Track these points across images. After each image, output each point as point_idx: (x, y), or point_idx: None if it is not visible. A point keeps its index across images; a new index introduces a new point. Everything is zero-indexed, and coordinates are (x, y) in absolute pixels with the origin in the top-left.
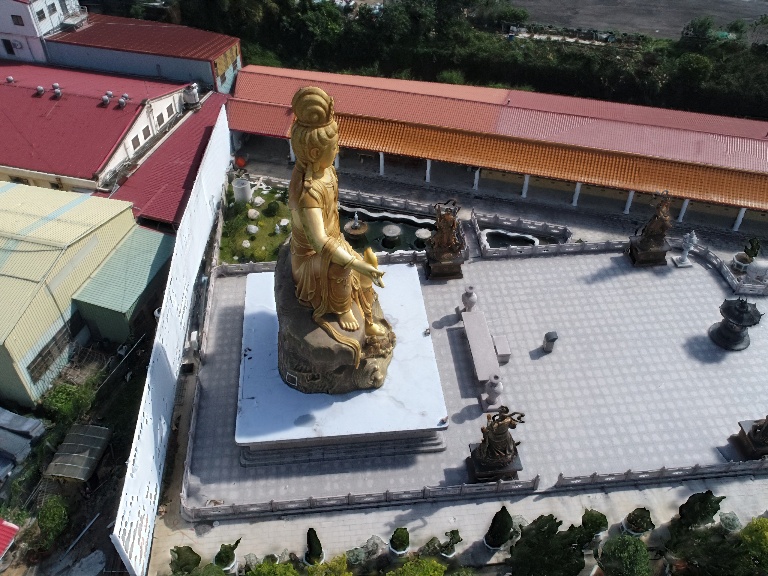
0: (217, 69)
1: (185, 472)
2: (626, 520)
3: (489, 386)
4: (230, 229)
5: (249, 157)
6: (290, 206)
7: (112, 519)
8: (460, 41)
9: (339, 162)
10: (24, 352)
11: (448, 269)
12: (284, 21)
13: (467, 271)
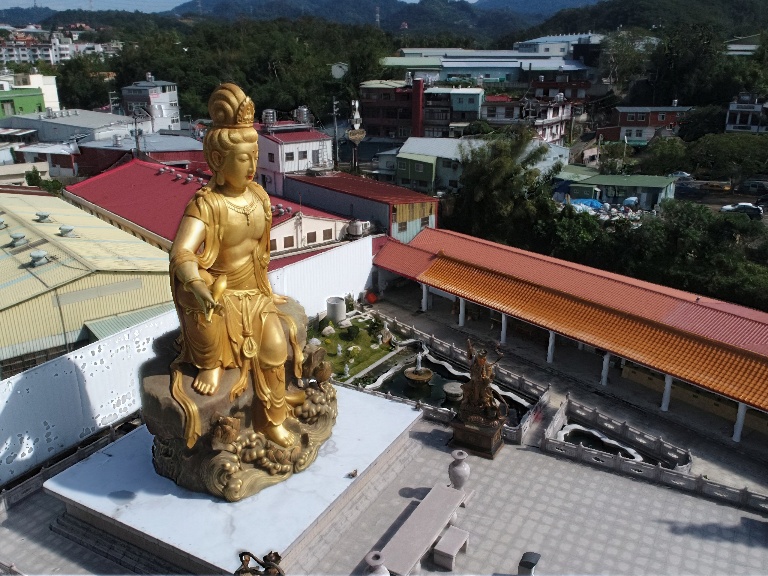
0: (396, 215)
1: None
2: None
3: (366, 568)
4: None
5: (386, 298)
6: None
7: None
8: (724, 269)
9: (467, 322)
10: (2, 344)
11: (475, 439)
12: (538, 224)
13: (506, 455)
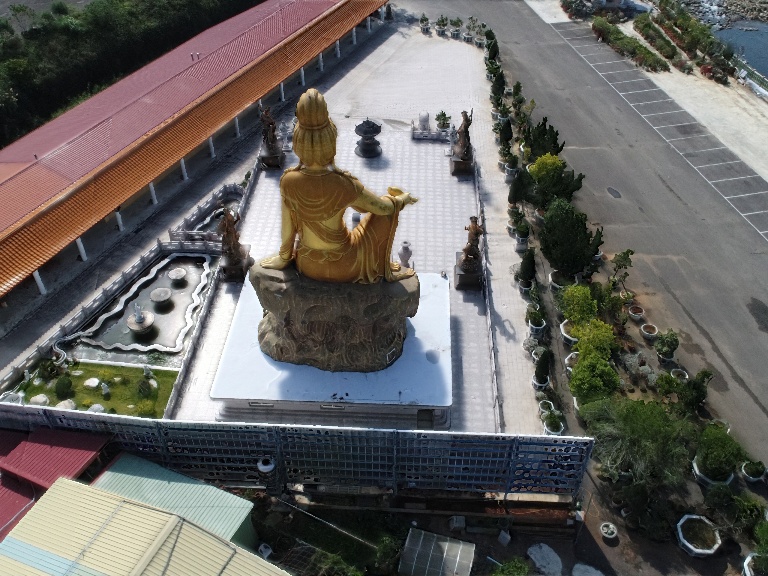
0: None
1: None
2: (513, 226)
3: (407, 253)
4: None
5: None
6: (340, 208)
7: (494, 544)
8: None
9: None
10: None
11: (247, 261)
12: None
13: None
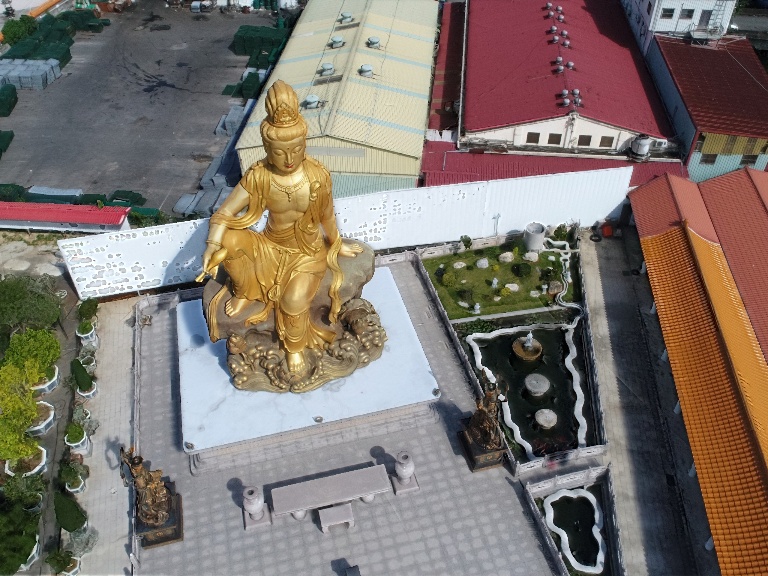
0: (703, 143)
1: (171, 292)
2: None
3: None
4: (464, 243)
5: (627, 237)
6: None
7: None
8: None
9: None
10: None
11: None
12: None
13: (489, 476)
